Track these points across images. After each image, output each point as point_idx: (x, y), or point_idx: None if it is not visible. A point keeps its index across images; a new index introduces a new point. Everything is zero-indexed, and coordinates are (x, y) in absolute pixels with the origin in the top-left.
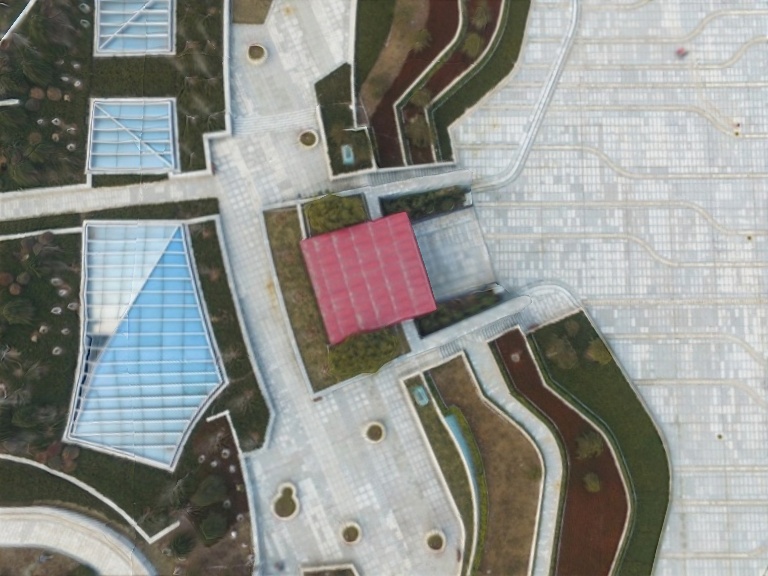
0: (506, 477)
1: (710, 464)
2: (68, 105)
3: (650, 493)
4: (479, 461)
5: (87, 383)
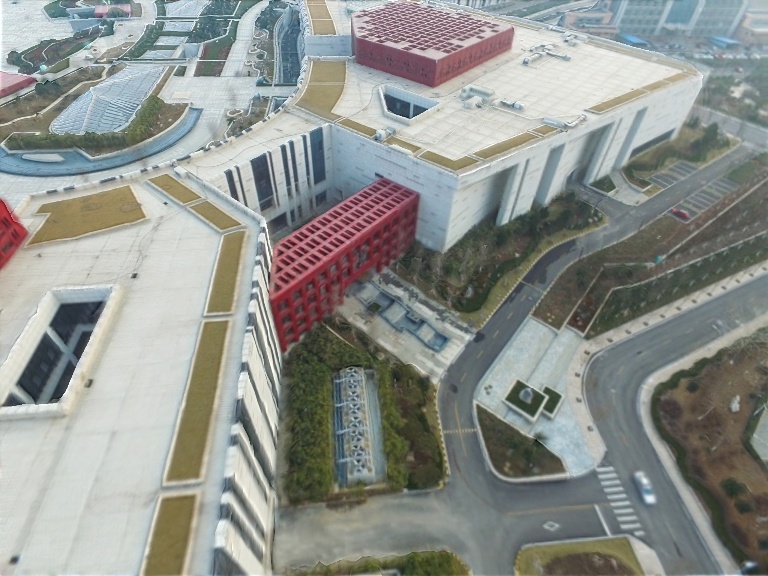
0: (94, 0)
1: (31, 7)
2: (198, 29)
3: (54, 3)
4: (100, 0)
5: (203, 4)
